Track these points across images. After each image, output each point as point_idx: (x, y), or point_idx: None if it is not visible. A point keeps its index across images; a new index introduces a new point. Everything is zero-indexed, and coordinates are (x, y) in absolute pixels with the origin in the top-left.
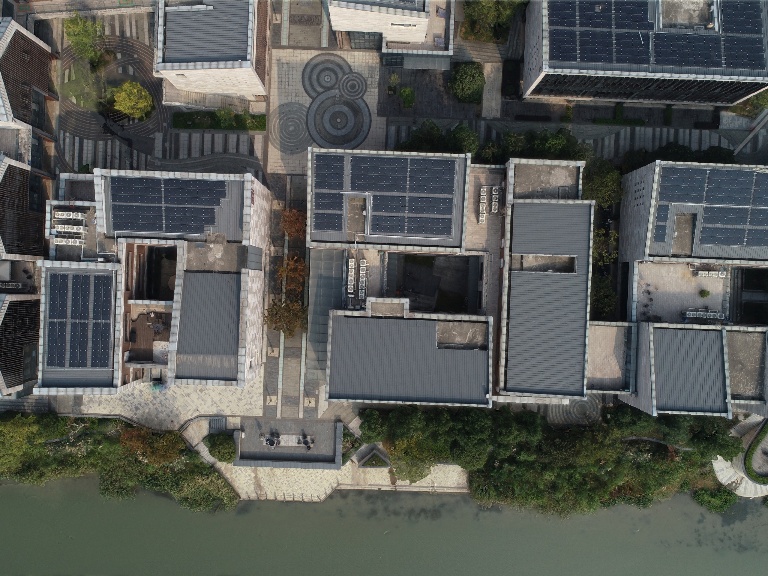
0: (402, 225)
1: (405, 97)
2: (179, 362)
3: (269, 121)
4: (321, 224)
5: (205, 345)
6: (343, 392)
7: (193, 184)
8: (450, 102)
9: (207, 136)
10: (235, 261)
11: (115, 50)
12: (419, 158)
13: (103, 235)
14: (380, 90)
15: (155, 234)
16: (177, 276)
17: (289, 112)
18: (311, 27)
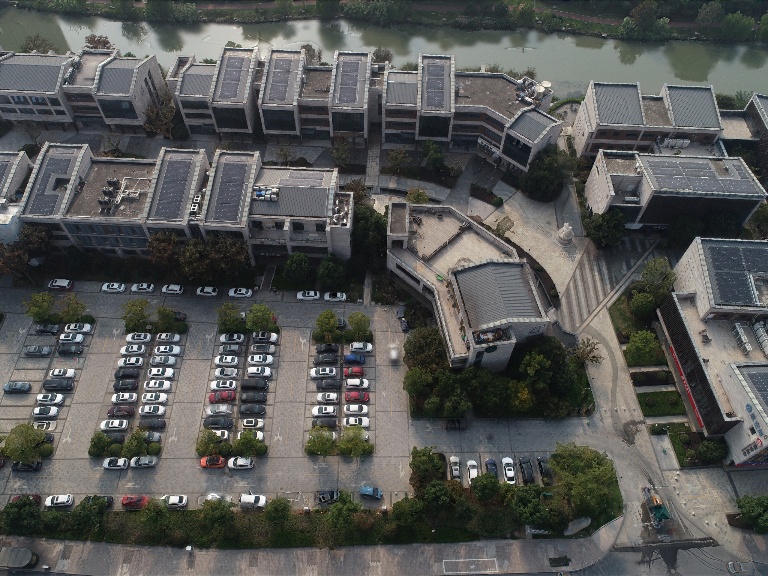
0: None
1: None
2: None
3: None
4: None
5: None
6: None
7: None
8: None
9: None
10: None
11: None
12: None
13: None
14: None
15: None
16: None
17: None
18: None
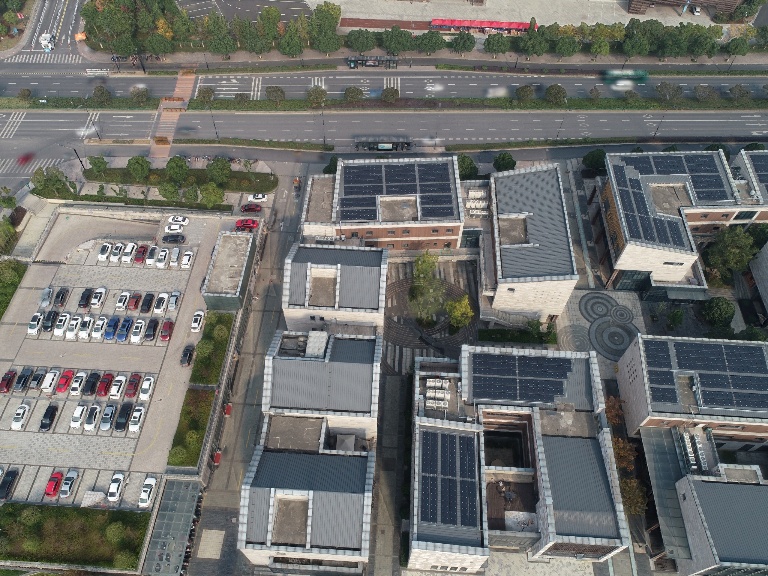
0: (730, 399)
1: (678, 316)
2: (556, 518)
3: (558, 338)
4: (658, 397)
5: (578, 502)
6: (731, 556)
7: (543, 360)
8: (705, 327)
9: (507, 347)
10: (586, 427)
11: (428, 287)
12: (731, 345)
13: (463, 402)
14: (645, 318)
15: (510, 402)
16: (537, 438)
17: (573, 331)
18: (579, 275)
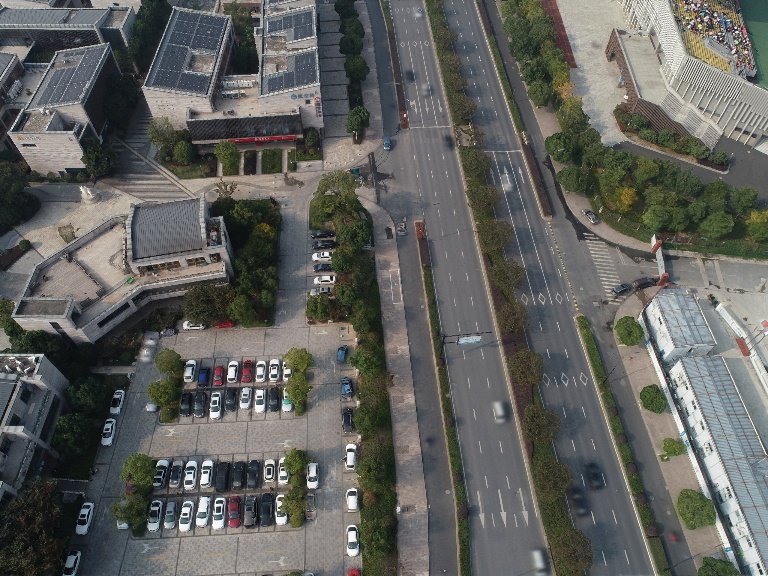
0: None
1: None
2: None
3: None
4: None
5: None
6: None
7: None
8: None
9: None
10: None
11: None
12: None
13: None
14: None
15: None
16: None
17: None
18: None
